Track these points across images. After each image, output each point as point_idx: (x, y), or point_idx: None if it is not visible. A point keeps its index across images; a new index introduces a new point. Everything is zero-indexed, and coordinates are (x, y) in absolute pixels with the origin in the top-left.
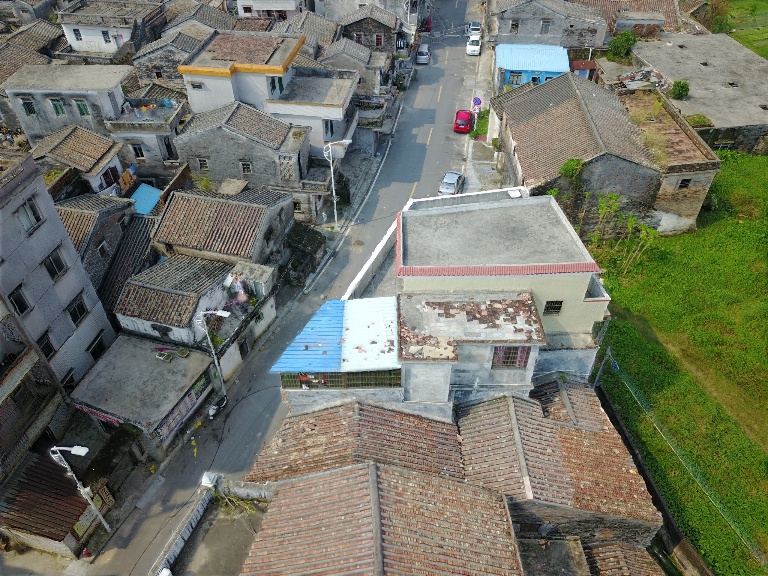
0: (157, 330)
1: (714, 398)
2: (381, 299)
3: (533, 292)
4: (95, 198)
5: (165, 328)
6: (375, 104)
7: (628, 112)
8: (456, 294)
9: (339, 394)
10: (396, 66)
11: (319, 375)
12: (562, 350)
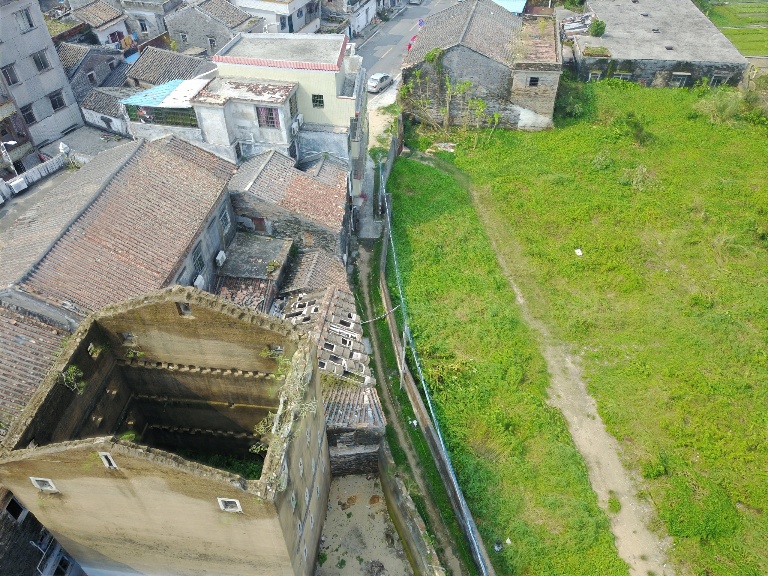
0: (103, 121)
1: (484, 223)
2: (206, 80)
3: (301, 85)
4: (98, 46)
5: (108, 119)
6: (340, 19)
7: (521, 31)
8: (251, 80)
9: (163, 130)
10: (386, 1)
11: (148, 111)
12: (322, 132)
